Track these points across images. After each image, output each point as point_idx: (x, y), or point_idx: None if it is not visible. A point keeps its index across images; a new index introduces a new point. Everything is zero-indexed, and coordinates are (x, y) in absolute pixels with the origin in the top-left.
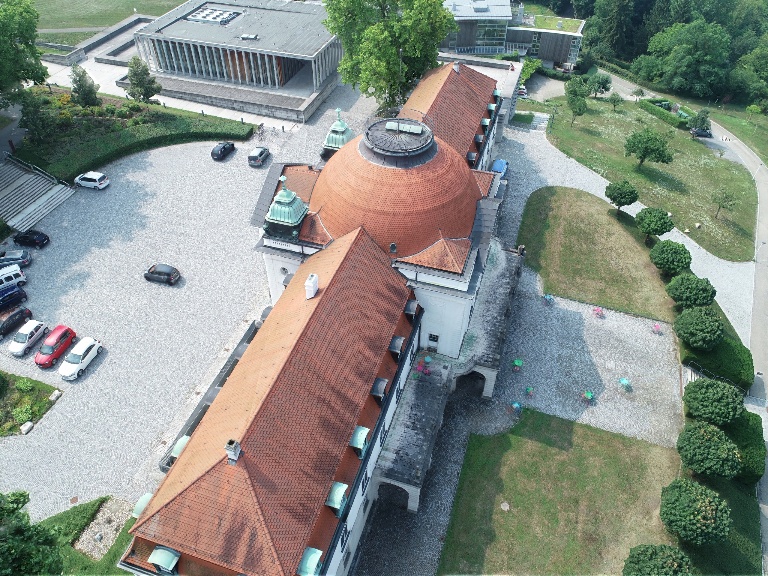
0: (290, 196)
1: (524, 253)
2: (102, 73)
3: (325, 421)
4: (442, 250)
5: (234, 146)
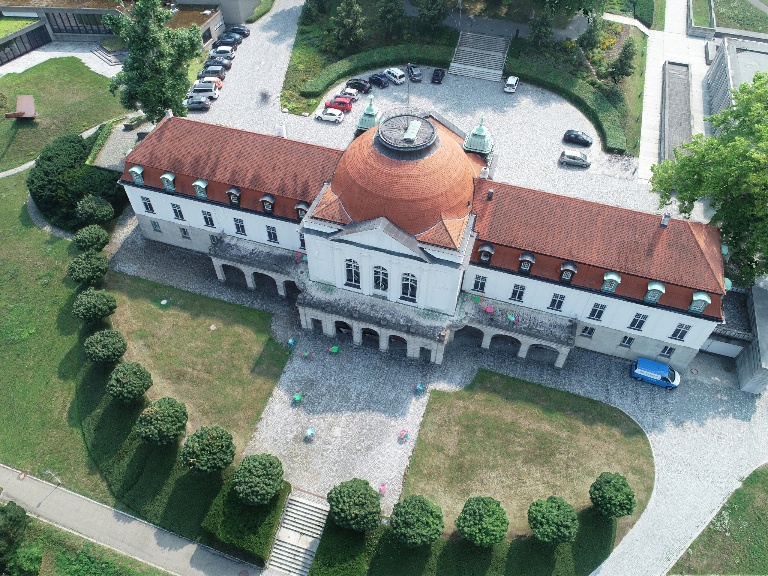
0: (369, 111)
1: (443, 341)
2: (684, 53)
3: (199, 159)
4: (330, 200)
5: (591, 145)
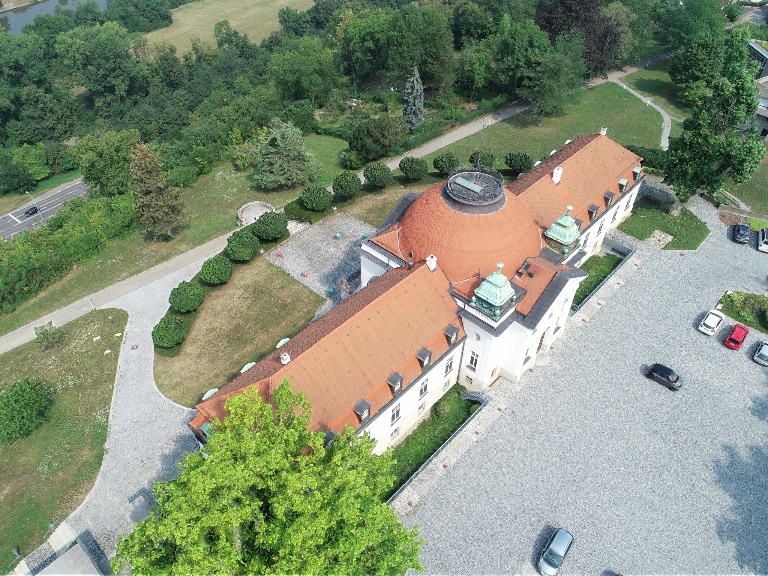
0: None
1: None
2: None
3: None
4: None
5: None
